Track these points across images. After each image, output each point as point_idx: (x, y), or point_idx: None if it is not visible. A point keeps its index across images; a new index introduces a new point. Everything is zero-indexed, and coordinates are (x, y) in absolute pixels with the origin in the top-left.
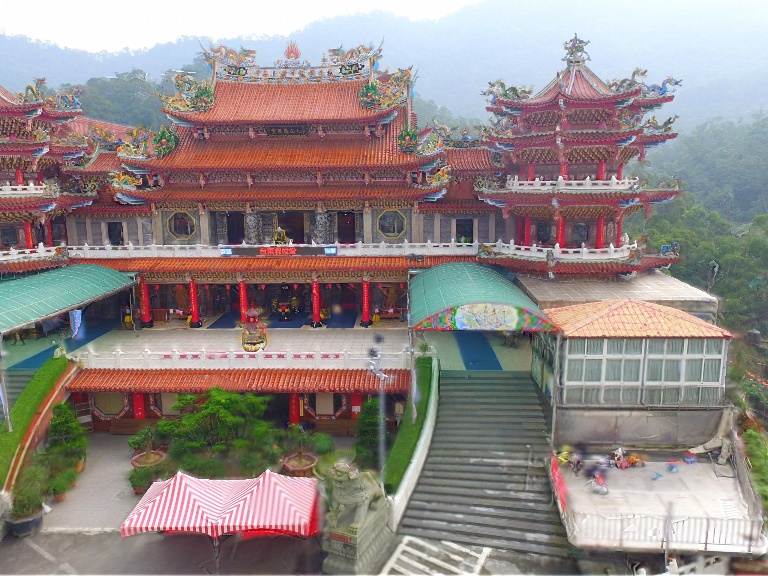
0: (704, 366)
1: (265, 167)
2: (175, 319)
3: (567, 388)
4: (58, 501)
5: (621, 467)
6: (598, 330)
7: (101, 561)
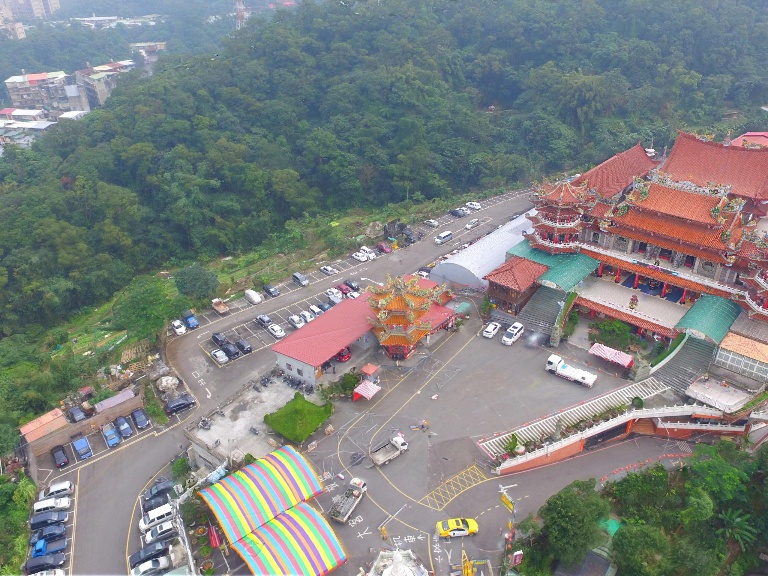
0: (763, 370)
1: (659, 233)
2: (610, 275)
3: (717, 359)
4: (571, 335)
5: (721, 385)
6: (731, 348)
7: (581, 354)
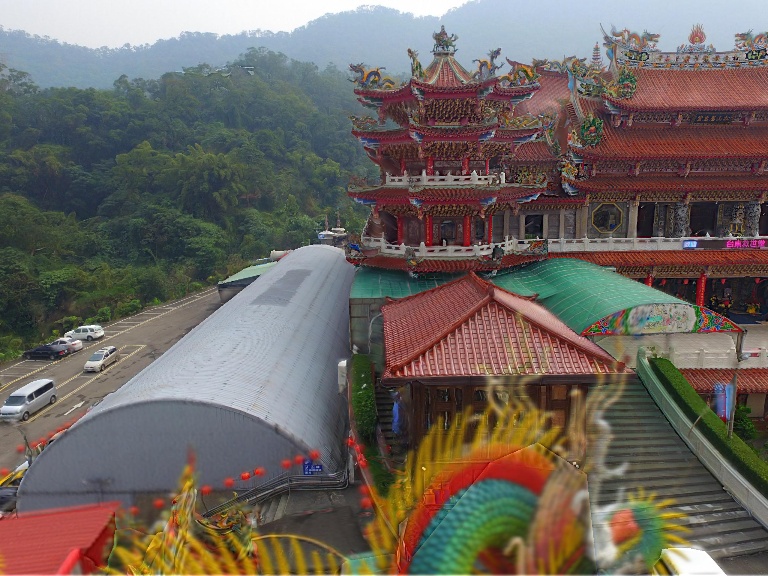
0: None
1: (716, 156)
2: None
3: None
4: None
5: None
6: None
7: None
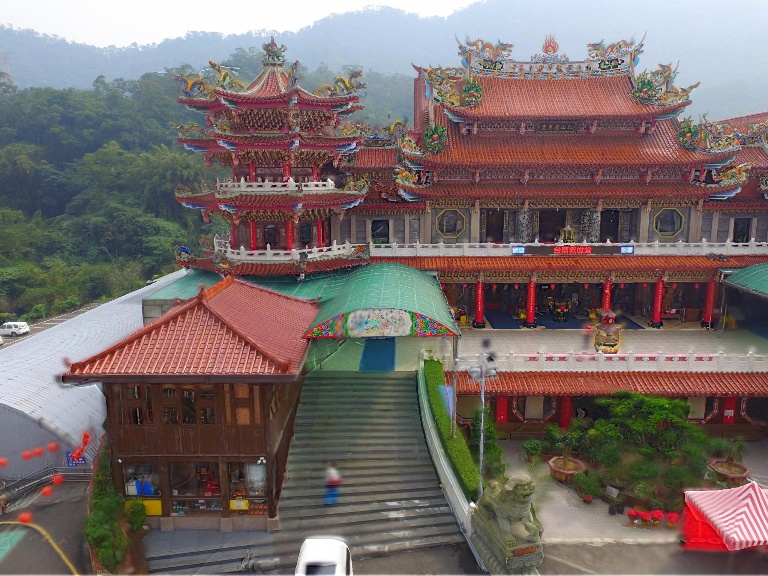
0: None
1: (550, 164)
2: None
3: None
4: None
5: None
6: None
7: (649, 574)
